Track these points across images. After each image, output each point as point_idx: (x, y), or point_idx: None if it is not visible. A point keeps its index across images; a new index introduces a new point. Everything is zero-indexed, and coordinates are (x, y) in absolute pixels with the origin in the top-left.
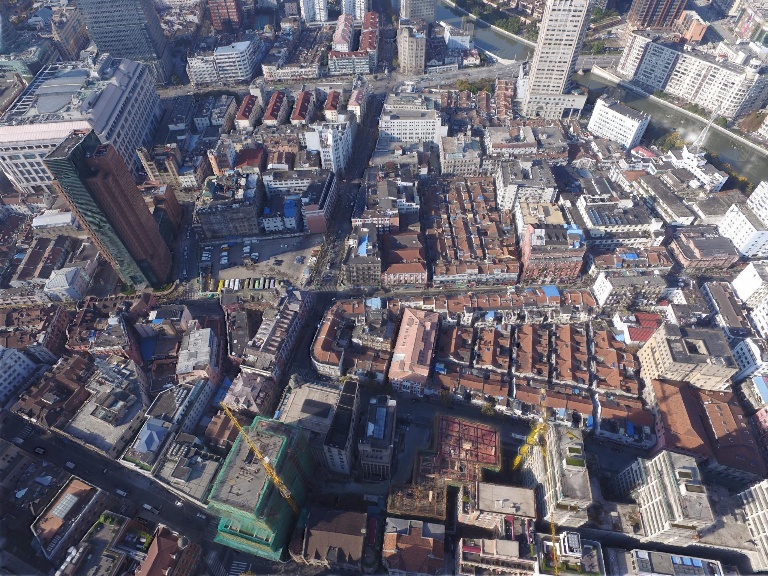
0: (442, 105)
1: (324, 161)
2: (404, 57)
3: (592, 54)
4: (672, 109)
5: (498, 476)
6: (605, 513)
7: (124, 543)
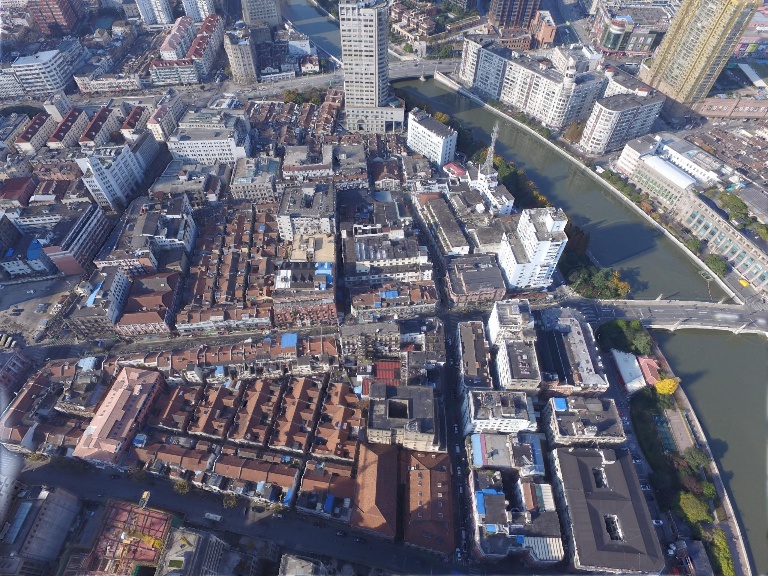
0: (260, 119)
1: (92, 191)
2: (232, 65)
3: (438, 58)
4: (504, 119)
5: None
6: None
7: None
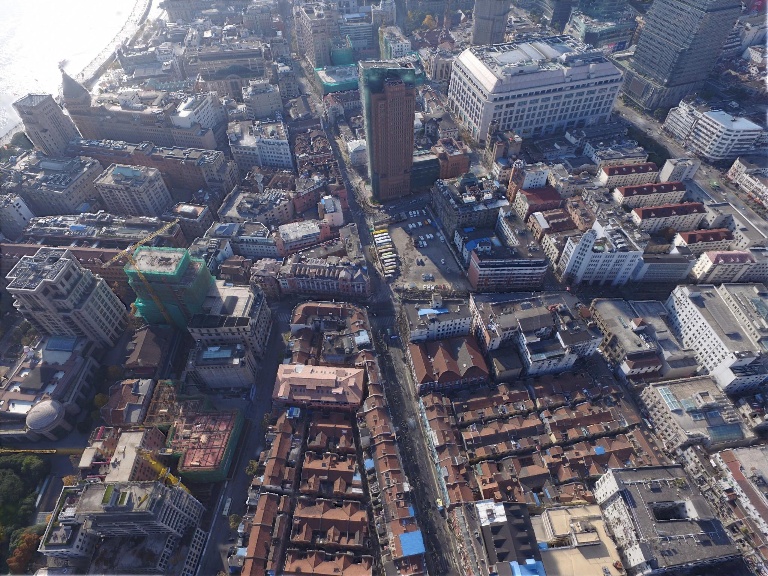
0: None
1: (565, 252)
2: None
3: None
4: None
5: (193, 486)
6: (105, 569)
7: (161, 240)
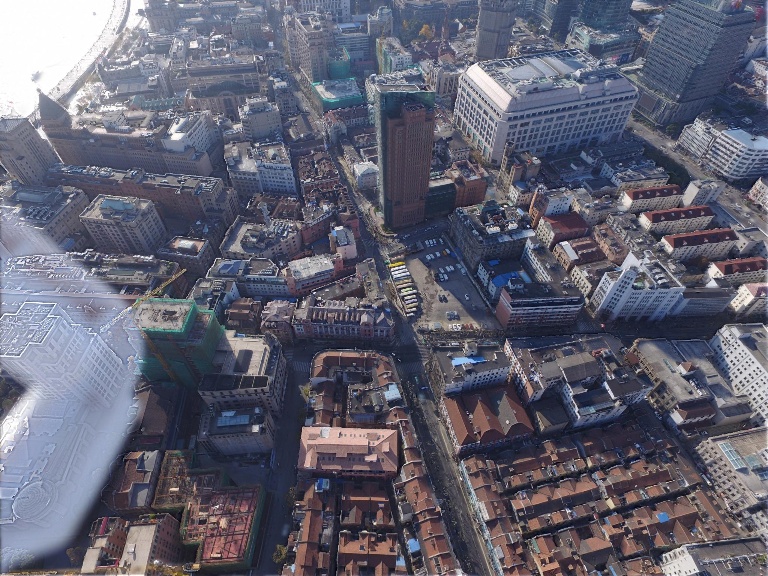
0: None
1: (600, 287)
2: None
3: None
4: None
5: None
6: None
7: (159, 282)
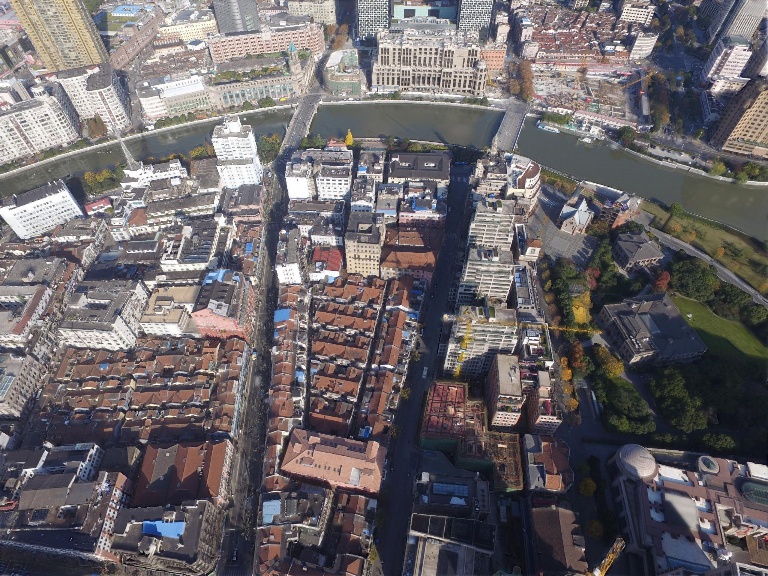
0: None
1: None
2: None
3: None
4: (33, 169)
5: None
6: None
7: None
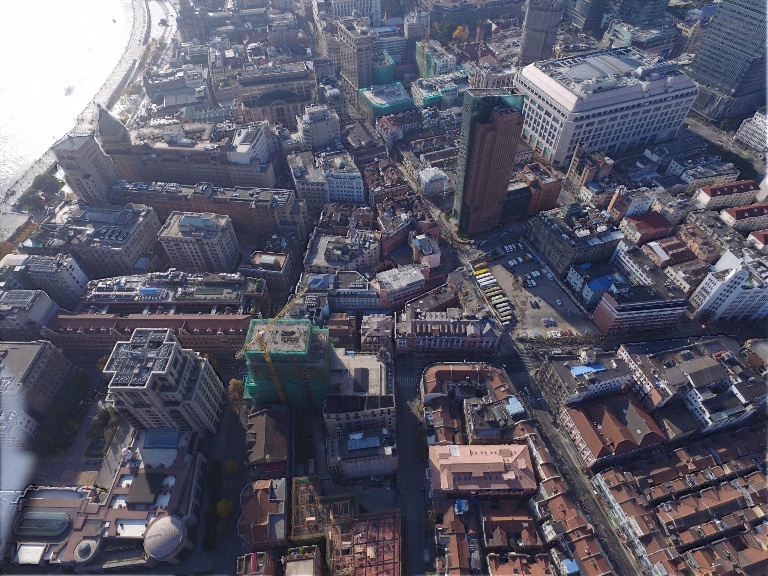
0: None
1: (702, 288)
2: None
3: None
4: None
5: None
6: None
7: (249, 300)
